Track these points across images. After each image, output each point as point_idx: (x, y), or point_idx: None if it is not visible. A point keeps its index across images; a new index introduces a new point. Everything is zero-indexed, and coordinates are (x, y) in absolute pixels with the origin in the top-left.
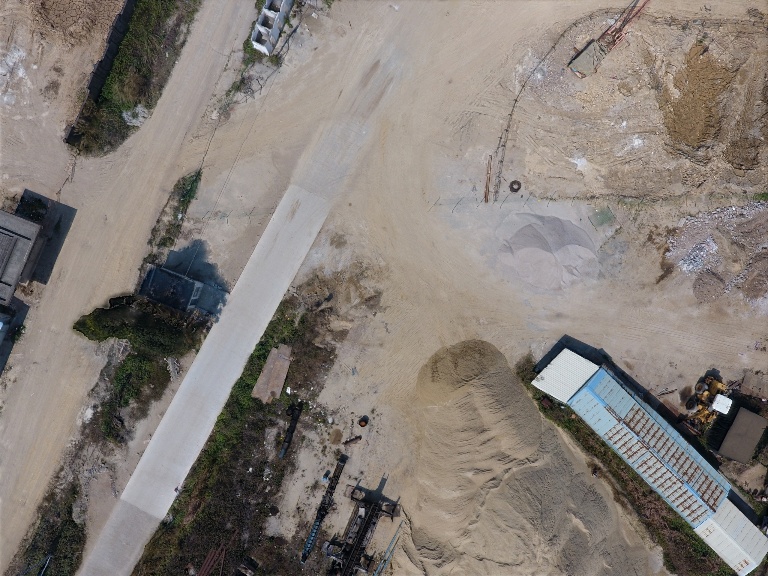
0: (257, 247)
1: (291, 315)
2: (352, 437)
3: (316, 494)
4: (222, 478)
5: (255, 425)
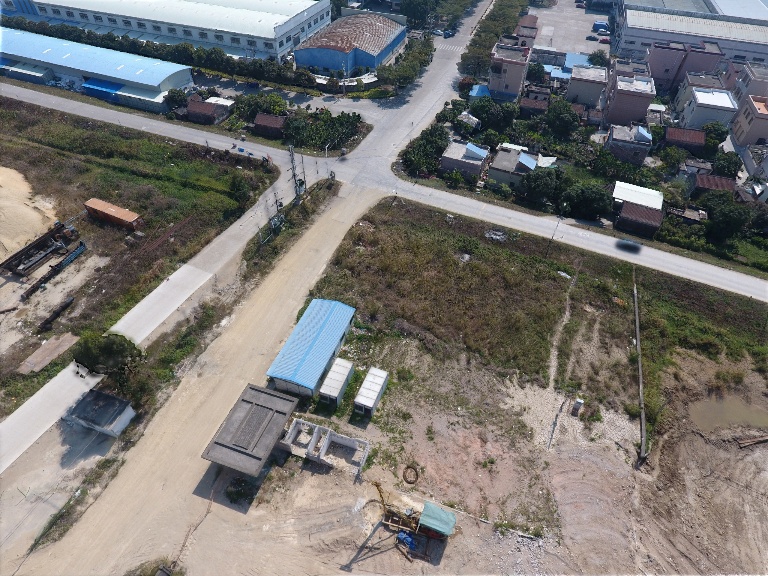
0: (8, 465)
1: (8, 402)
2: (8, 313)
3: (59, 279)
4: (126, 285)
5: (82, 317)
